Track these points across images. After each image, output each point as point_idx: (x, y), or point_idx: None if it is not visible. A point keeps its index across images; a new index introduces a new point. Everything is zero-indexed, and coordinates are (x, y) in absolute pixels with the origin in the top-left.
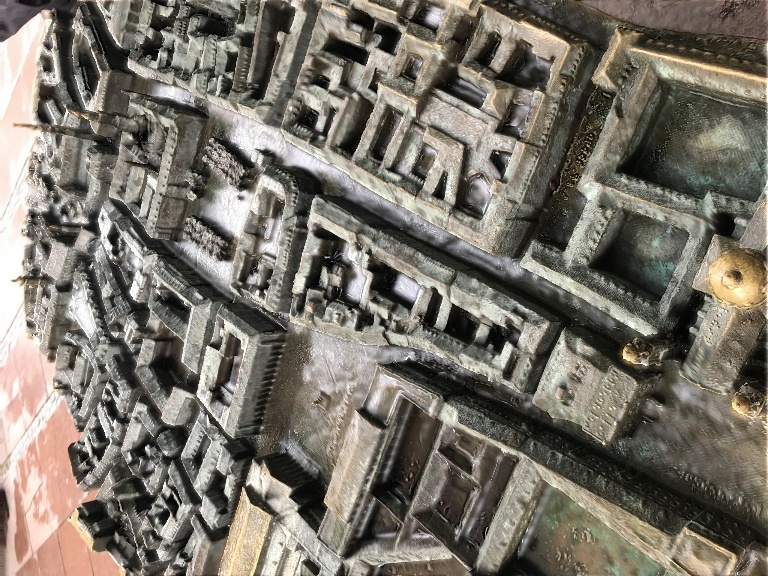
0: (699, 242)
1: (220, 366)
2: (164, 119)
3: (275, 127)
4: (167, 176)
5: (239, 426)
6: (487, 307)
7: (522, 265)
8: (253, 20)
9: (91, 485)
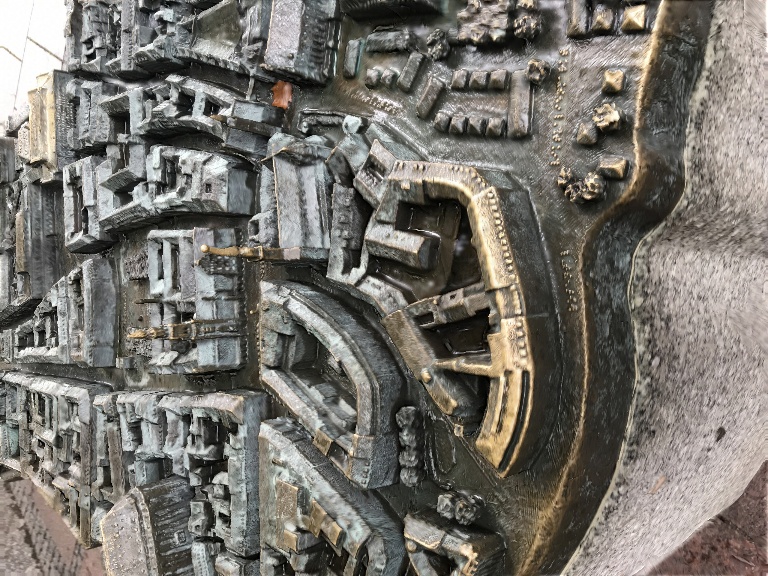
0: (6, 411)
1: None
2: None
3: None
4: None
5: None
6: None
7: None
8: None
9: None
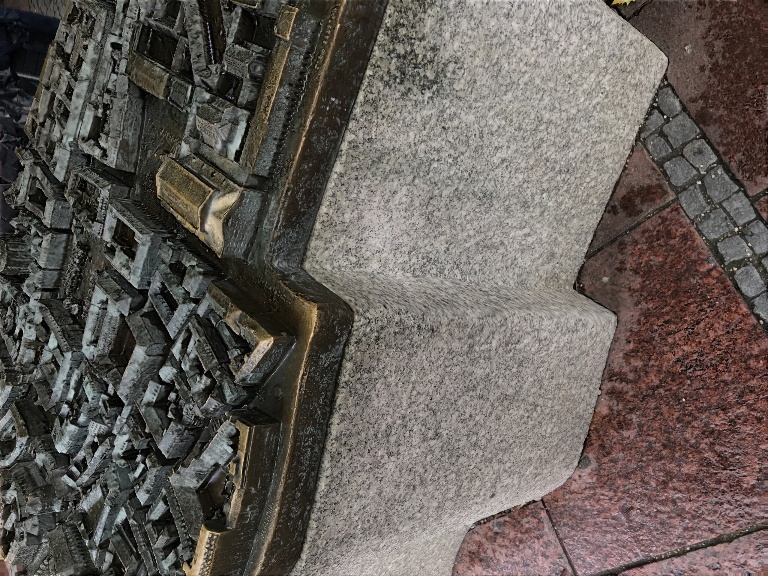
0: None
1: (124, 253)
2: (36, 316)
3: (65, 202)
4: (56, 323)
5: (150, 228)
6: (118, 8)
7: None
8: (34, 221)
9: None
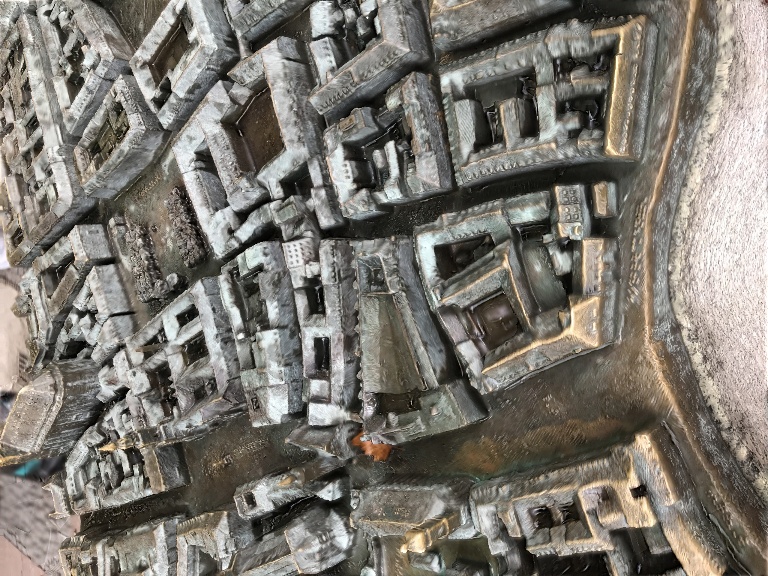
0: None
1: None
2: (133, 357)
3: (89, 225)
4: None
5: None
6: None
7: (27, 4)
8: None
9: (590, 21)
